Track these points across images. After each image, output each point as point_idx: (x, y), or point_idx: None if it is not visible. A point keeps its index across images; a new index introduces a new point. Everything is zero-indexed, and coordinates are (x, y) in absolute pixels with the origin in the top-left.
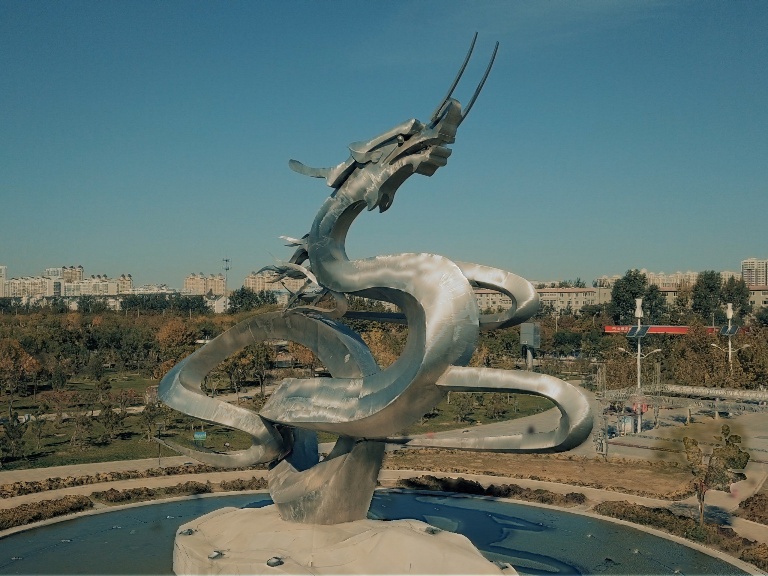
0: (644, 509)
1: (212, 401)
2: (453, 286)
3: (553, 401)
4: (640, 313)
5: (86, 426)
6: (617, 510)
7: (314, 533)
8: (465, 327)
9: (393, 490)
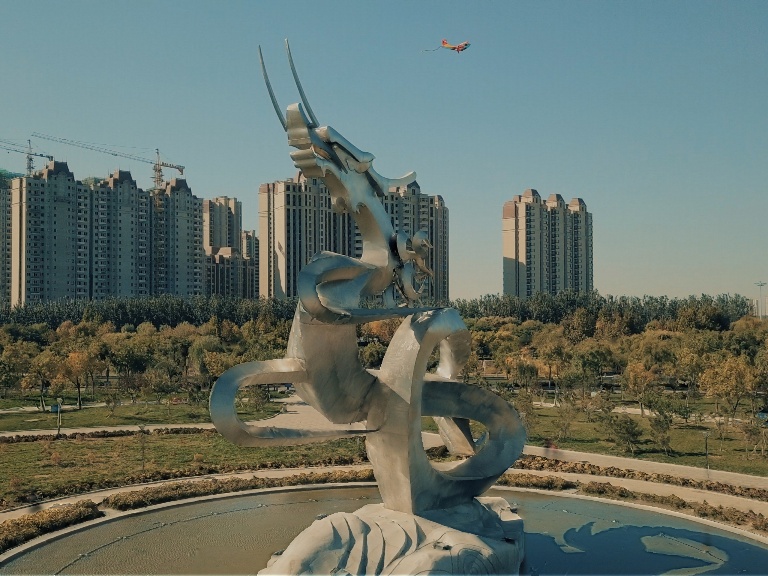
0: None
1: None
2: None
3: None
4: None
5: (747, 434)
6: None
7: None
8: None
9: None
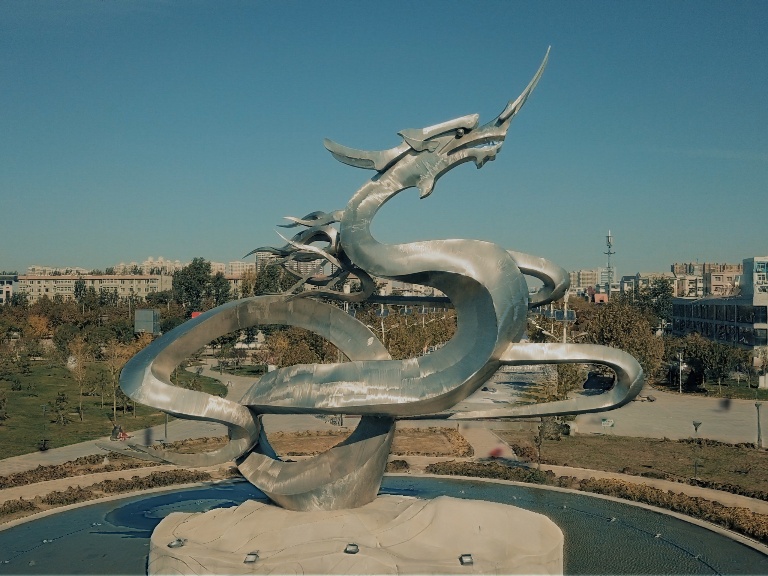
0: (476, 465)
1: (201, 395)
2: (508, 271)
3: (618, 367)
4: None
5: None
6: (454, 469)
7: (359, 516)
8: (521, 308)
9: (236, 480)
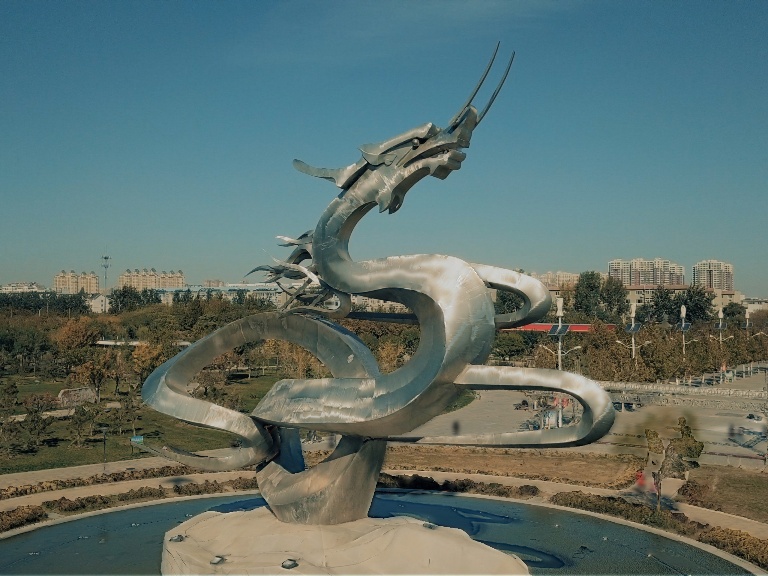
0: (599, 498)
1: (203, 404)
2: (469, 287)
3: (577, 397)
4: (561, 312)
5: (14, 433)
6: (574, 500)
7: (322, 534)
8: (482, 327)
9: None
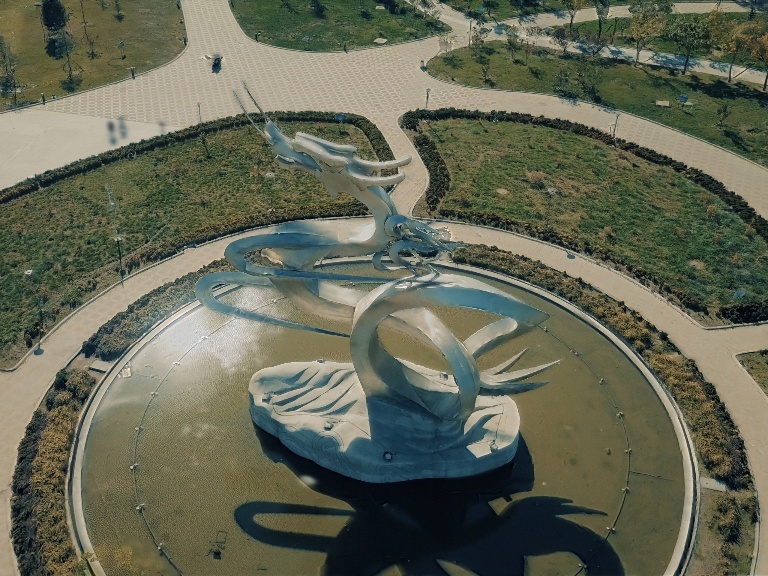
0: None
1: None
2: None
3: None
4: None
5: None
6: None
7: None
8: None
9: None
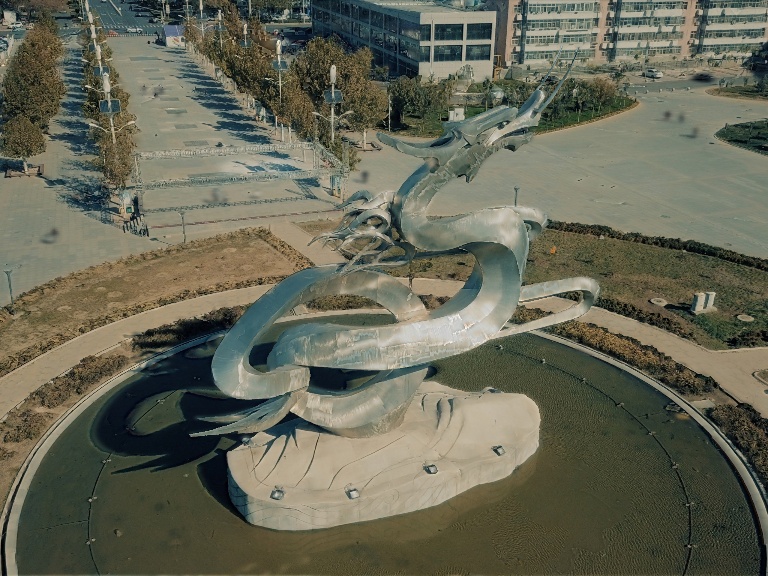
0: None
1: (285, 375)
2: None
3: (589, 292)
4: (109, 88)
5: None
6: (336, 303)
7: (413, 435)
8: None
9: (159, 359)
